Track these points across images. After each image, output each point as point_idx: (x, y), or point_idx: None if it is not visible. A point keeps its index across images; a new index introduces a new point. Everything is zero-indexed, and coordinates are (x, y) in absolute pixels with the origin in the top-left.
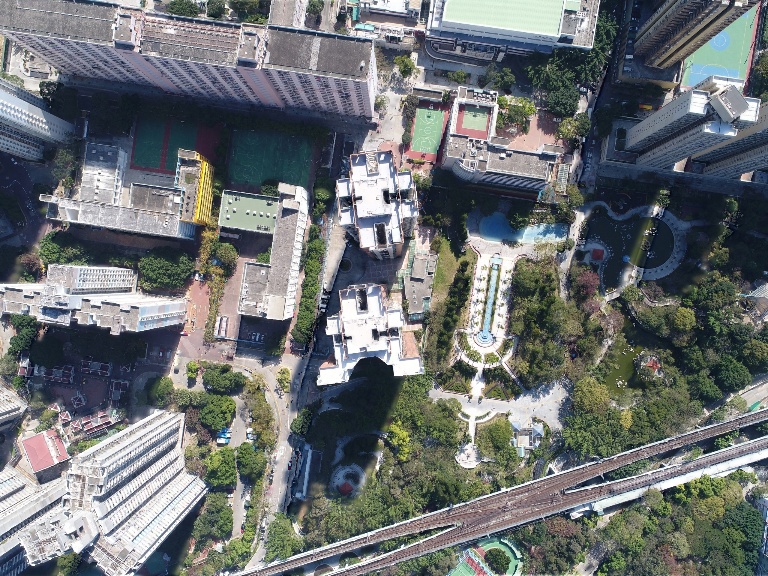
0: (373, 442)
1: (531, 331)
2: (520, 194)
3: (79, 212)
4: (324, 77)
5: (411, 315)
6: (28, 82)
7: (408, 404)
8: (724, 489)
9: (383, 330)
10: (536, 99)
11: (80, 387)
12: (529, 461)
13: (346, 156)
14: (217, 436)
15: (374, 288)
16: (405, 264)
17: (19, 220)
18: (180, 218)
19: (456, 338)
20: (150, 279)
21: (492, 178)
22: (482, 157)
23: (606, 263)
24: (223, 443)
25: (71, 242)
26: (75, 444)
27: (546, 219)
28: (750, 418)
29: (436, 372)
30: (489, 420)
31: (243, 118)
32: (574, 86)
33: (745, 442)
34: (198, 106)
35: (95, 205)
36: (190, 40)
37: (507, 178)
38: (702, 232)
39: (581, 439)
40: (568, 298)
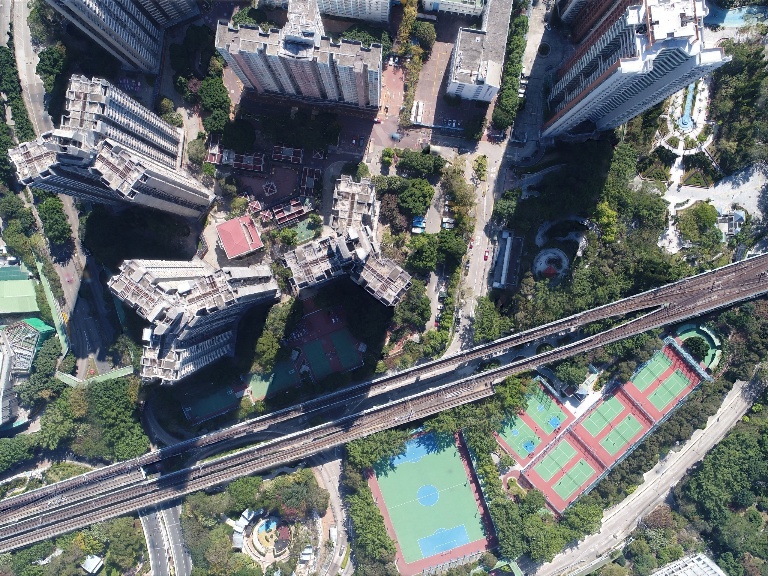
0: (579, 224)
1: (740, 109)
2: None
3: None
4: None
5: None
6: None
7: (616, 183)
8: None
9: (691, 15)
10: None
11: (269, 177)
12: (728, 248)
13: None
14: (411, 227)
15: None
16: None
17: None
18: None
19: None
20: None
21: None
22: None
23: None
24: (418, 233)
25: (265, 19)
26: None
27: (748, 2)
28: None
29: None
30: (688, 207)
31: None
32: None
33: None
34: None
35: None
36: None
37: None
38: None
39: None
40: None
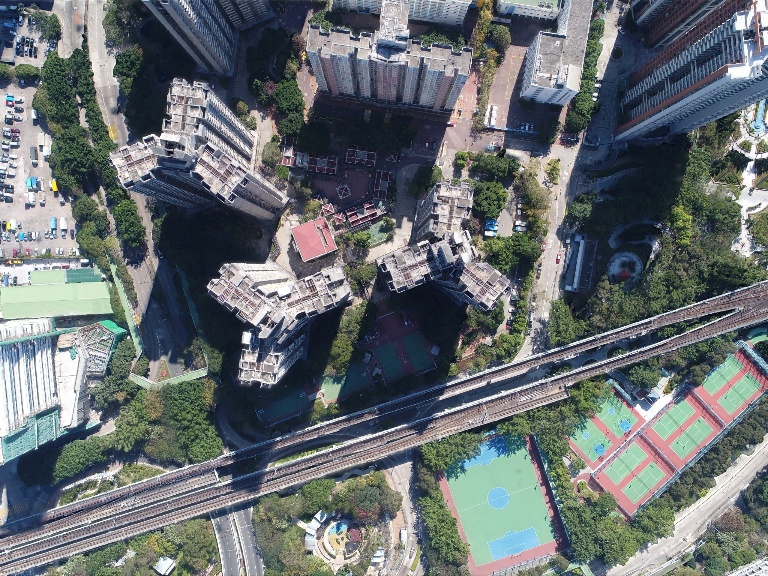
0: None
1: None
2: None
3: None
4: None
5: None
6: None
7: (691, 187)
8: None
9: None
10: None
11: (342, 180)
12: None
13: None
14: (483, 230)
15: None
16: None
17: None
18: None
19: None
20: None
21: None
22: None
23: None
24: (490, 236)
25: (341, 23)
26: None
27: None
28: None
29: None
30: (760, 211)
31: None
32: None
33: None
34: None
35: None
36: None
37: None
38: None
39: None
40: None
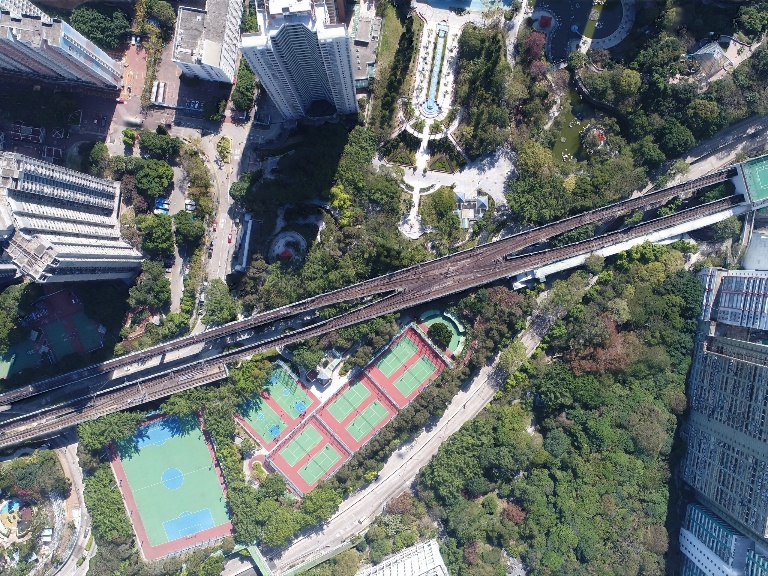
0: (314, 207)
1: (476, 94)
2: None
3: None
4: None
5: (355, 82)
6: None
7: (350, 167)
8: (665, 255)
9: None
10: None
11: None
12: (473, 234)
13: None
14: (155, 208)
15: None
16: (350, 31)
17: None
18: None
19: (401, 108)
20: (82, 34)
21: None
22: None
23: (554, 33)
24: None
25: None
26: None
27: None
28: (693, 184)
29: (380, 141)
30: (433, 192)
31: None
32: None
33: (687, 209)
34: None
35: None
36: None
37: None
38: (651, 0)
39: (524, 201)
40: None
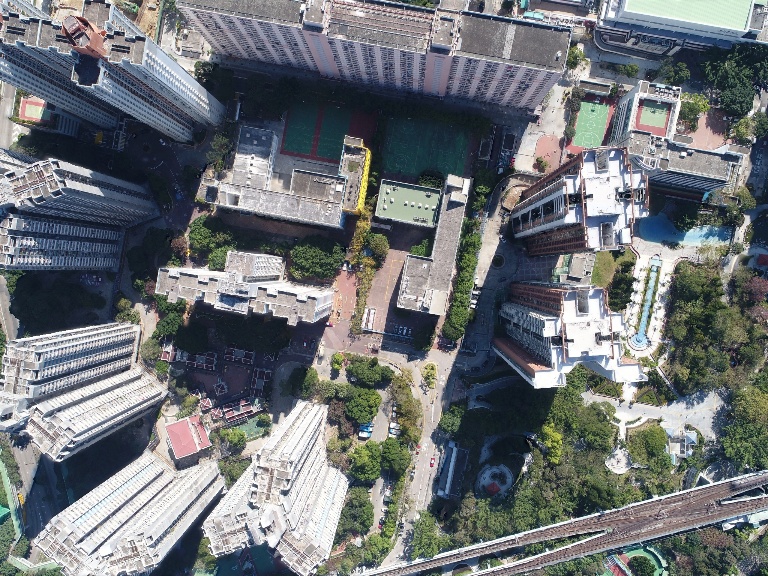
0: (524, 443)
1: (693, 336)
2: (684, 194)
3: (240, 197)
4: (517, 67)
5: None
6: (179, 61)
7: (562, 406)
8: None
9: (607, 334)
10: (706, 96)
11: (221, 374)
12: (679, 469)
13: (505, 149)
14: (359, 429)
15: (595, 290)
16: (560, 262)
17: (166, 202)
18: (342, 207)
19: None
20: (302, 268)
21: (665, 177)
22: (662, 155)
23: None
24: (365, 437)
25: (221, 227)
26: (215, 431)
27: (710, 221)
28: None
29: (589, 374)
30: (640, 425)
31: (403, 106)
32: (751, 84)
33: None
34: (358, 92)
35: (256, 190)
36: (379, 24)
37: (684, 178)
38: None
39: (743, 450)
40: (729, 304)
